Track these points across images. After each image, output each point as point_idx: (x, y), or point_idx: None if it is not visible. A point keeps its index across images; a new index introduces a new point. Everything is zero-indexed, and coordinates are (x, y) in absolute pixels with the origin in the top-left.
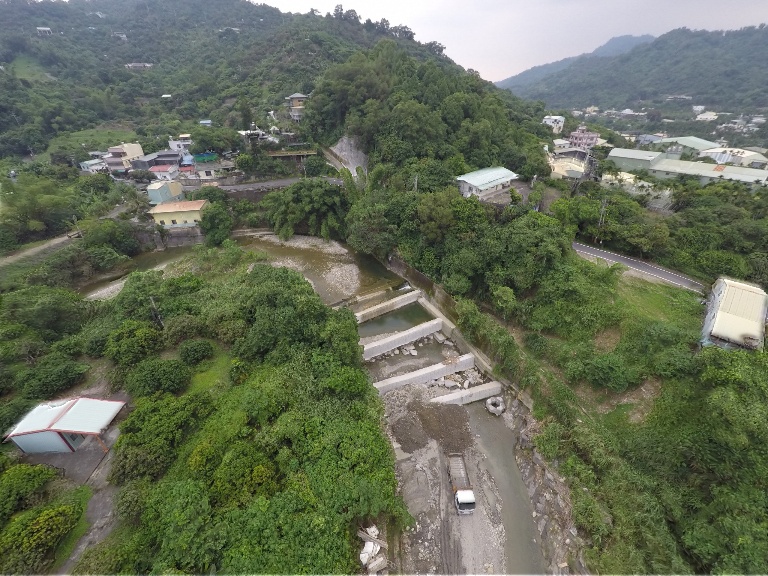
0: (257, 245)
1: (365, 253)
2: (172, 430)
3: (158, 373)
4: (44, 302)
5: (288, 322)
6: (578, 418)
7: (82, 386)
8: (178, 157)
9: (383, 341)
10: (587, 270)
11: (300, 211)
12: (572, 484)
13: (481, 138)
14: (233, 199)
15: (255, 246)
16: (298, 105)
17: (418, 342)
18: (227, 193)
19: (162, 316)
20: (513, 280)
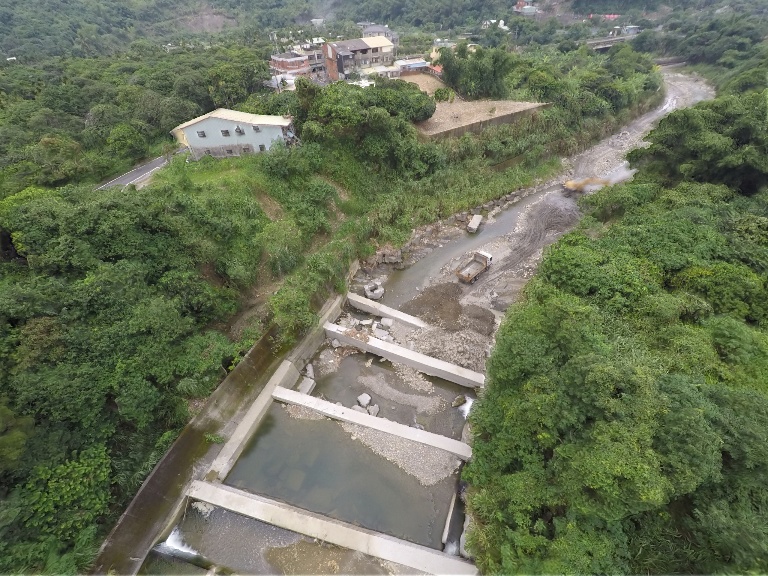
0: None
1: None
2: None
3: None
4: None
5: None
6: None
7: None
8: None
9: (400, 429)
10: None
11: None
12: None
13: None
14: None
15: None
16: None
17: None
18: None
19: None
20: (199, 262)
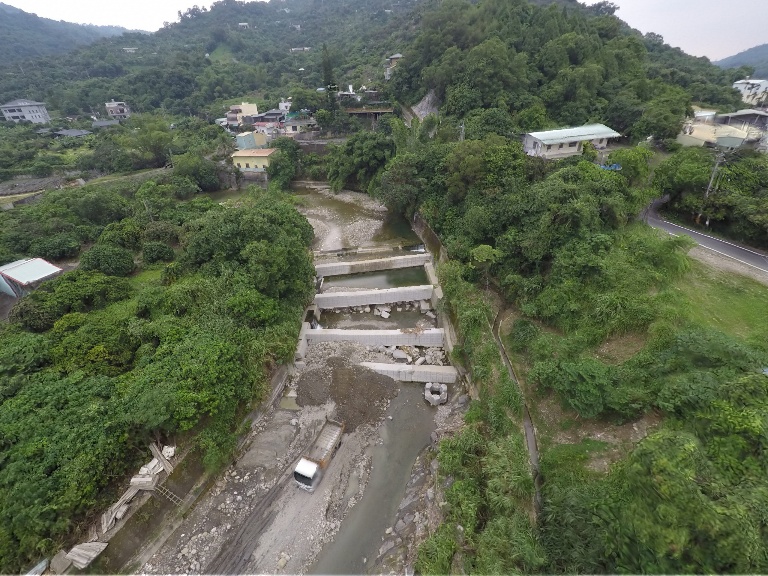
0: (311, 196)
1: (397, 211)
2: (71, 298)
3: (99, 254)
4: (88, 196)
5: (225, 237)
6: (509, 434)
7: (72, 259)
8: (280, 115)
9: (353, 293)
10: (638, 247)
11: (350, 164)
12: (448, 513)
13: (579, 86)
14: (301, 150)
15: (308, 196)
16: (393, 65)
17: (398, 306)
18: (299, 145)
19: None
20: None
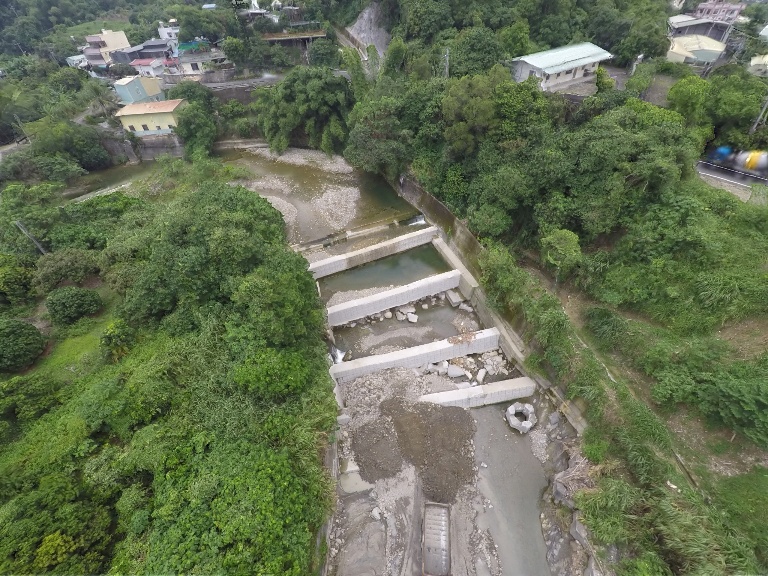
0: (246, 160)
1: (372, 173)
2: None
3: None
4: None
5: (192, 271)
6: (669, 479)
7: None
8: (166, 48)
9: (368, 299)
10: (724, 206)
11: (293, 113)
12: None
13: None
14: (217, 99)
15: (243, 161)
16: None
17: (422, 302)
18: (211, 91)
19: (52, 249)
20: (580, 218)
